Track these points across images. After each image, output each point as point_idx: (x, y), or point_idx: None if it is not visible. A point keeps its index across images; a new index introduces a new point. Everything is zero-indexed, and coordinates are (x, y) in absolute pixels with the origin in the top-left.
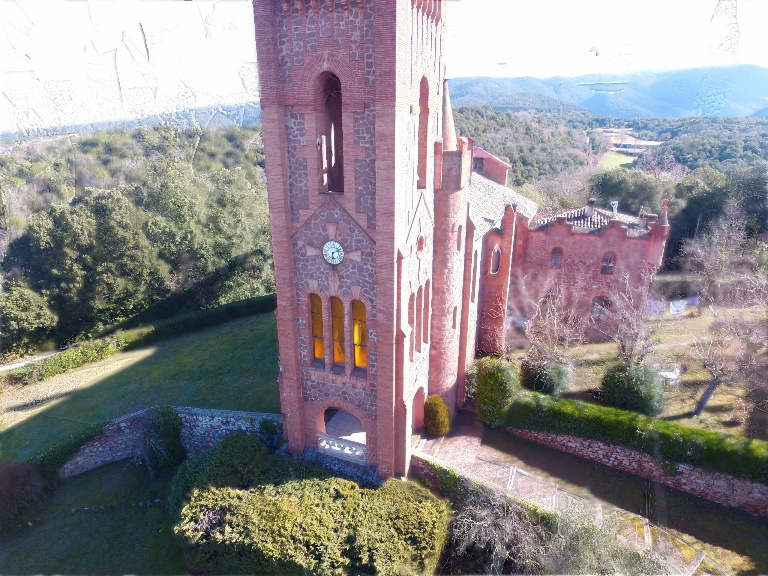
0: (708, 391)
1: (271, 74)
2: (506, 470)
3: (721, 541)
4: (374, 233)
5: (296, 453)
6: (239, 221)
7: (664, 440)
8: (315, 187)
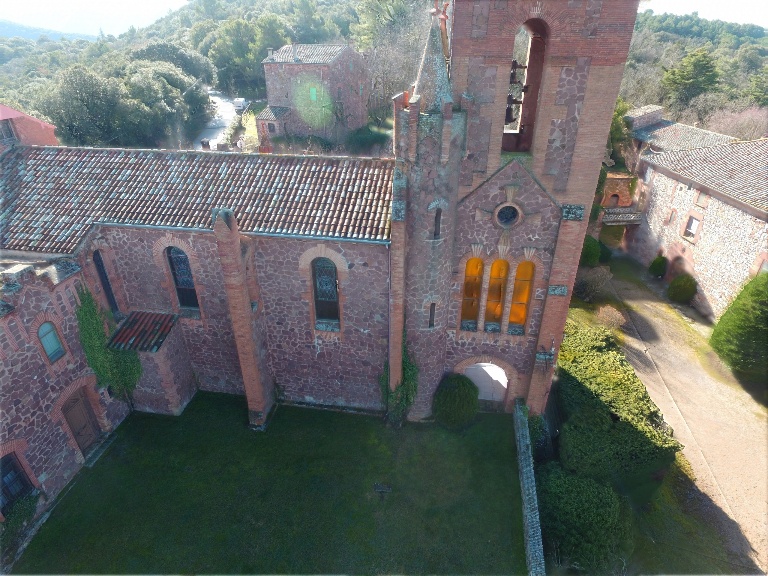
0: None
1: None
2: None
3: None
4: None
5: None
6: None
7: None
8: None
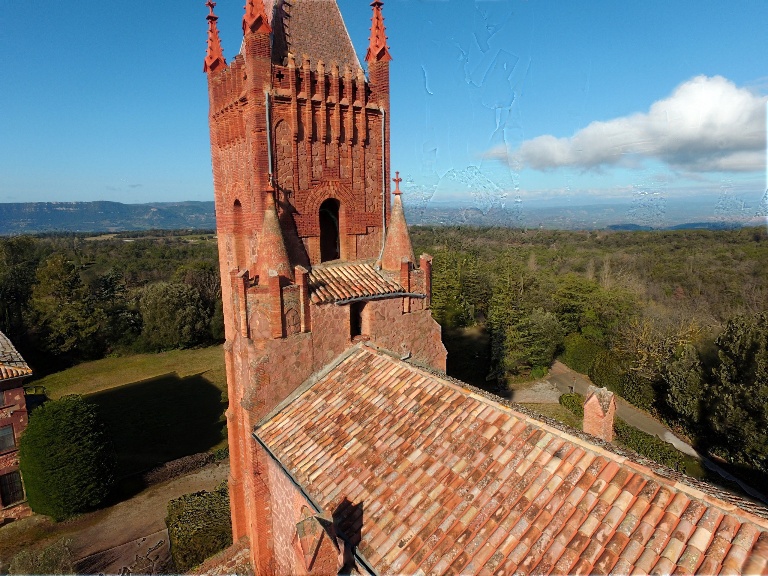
0: None
1: None
2: None
3: None
4: None
5: None
6: None
7: None
8: None
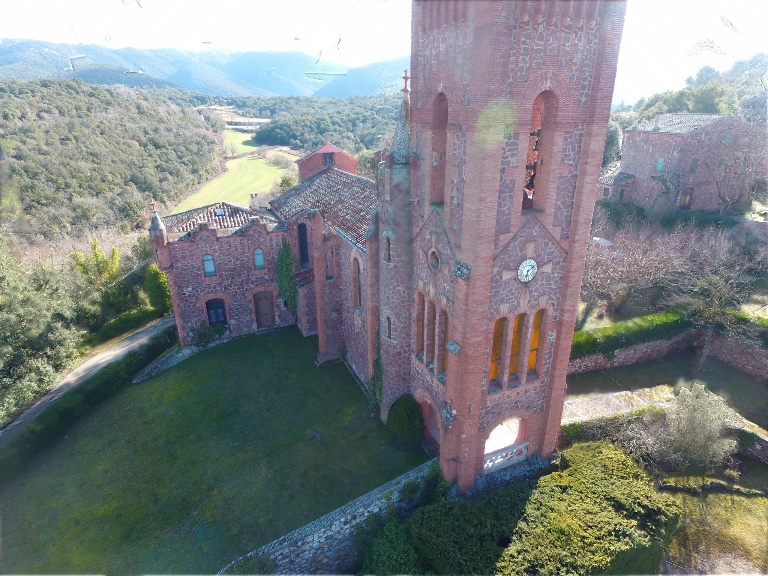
0: (590, 301)
1: (503, 90)
2: (564, 406)
3: (653, 383)
4: (565, 242)
5: (468, 490)
6: (1, 280)
7: (608, 339)
8: (519, 209)
